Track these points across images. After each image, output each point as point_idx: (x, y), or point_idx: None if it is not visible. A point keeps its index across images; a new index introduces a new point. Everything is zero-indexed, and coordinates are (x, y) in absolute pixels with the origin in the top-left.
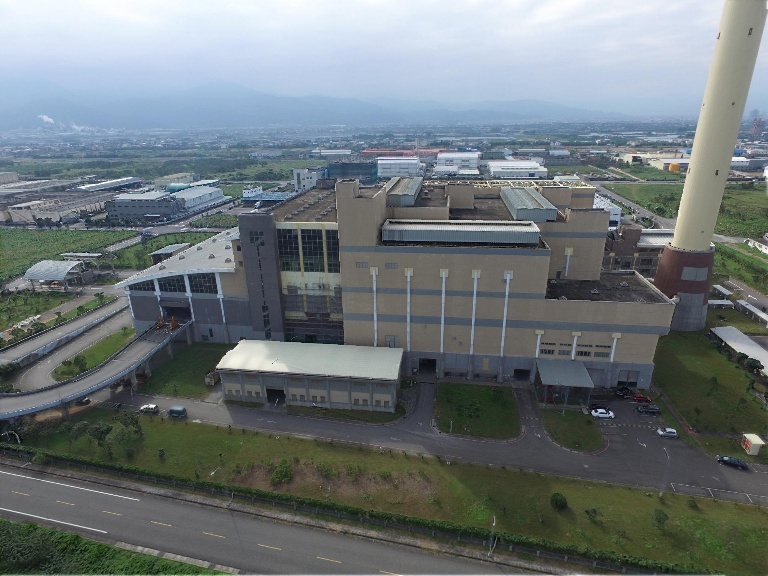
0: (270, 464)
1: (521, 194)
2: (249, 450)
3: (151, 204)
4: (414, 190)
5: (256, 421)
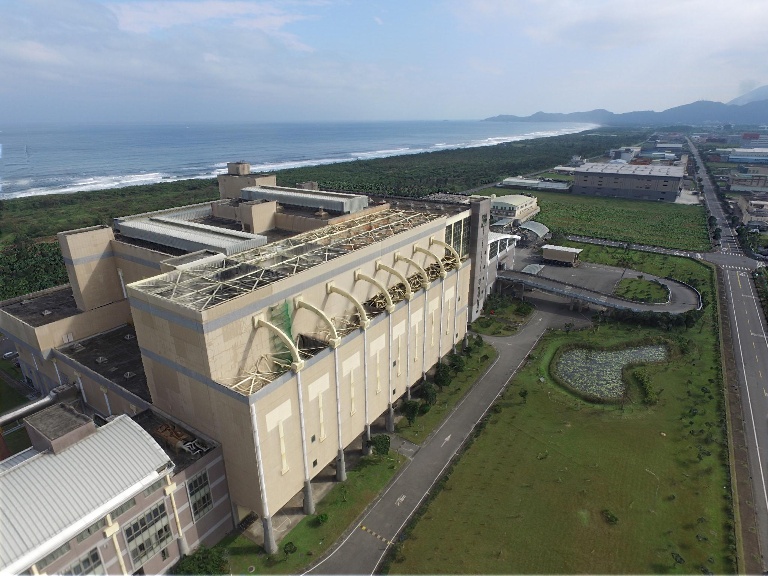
0: None
1: (209, 235)
2: None
3: None
4: (260, 191)
5: None
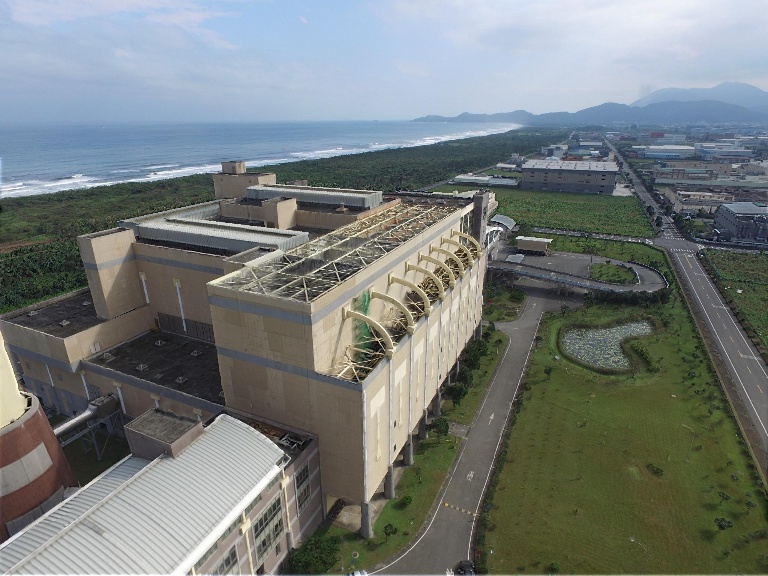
0: None
1: (246, 233)
2: None
3: (732, 218)
4: (269, 189)
5: None
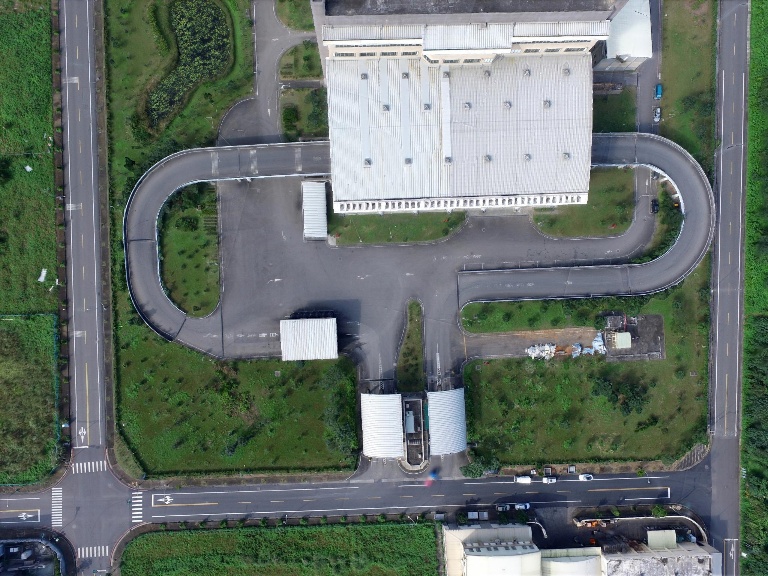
0: (697, 4)
1: None
2: (683, 26)
3: None
4: None
5: (653, 36)
